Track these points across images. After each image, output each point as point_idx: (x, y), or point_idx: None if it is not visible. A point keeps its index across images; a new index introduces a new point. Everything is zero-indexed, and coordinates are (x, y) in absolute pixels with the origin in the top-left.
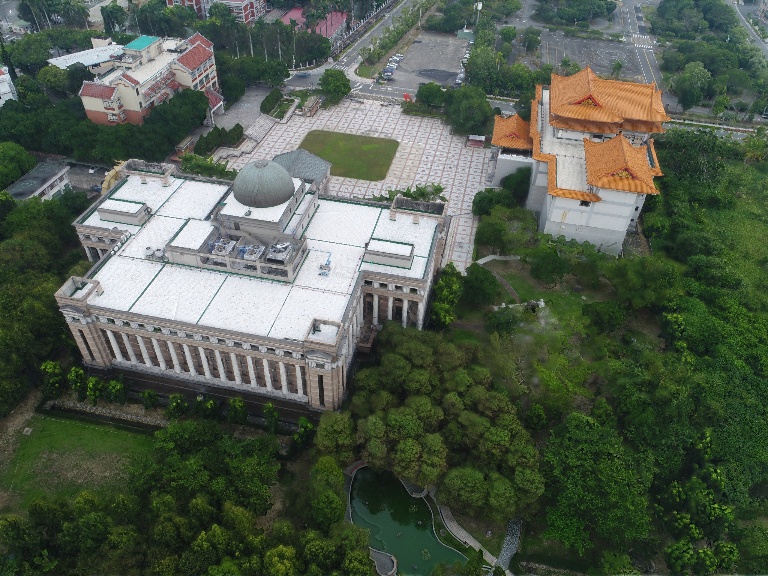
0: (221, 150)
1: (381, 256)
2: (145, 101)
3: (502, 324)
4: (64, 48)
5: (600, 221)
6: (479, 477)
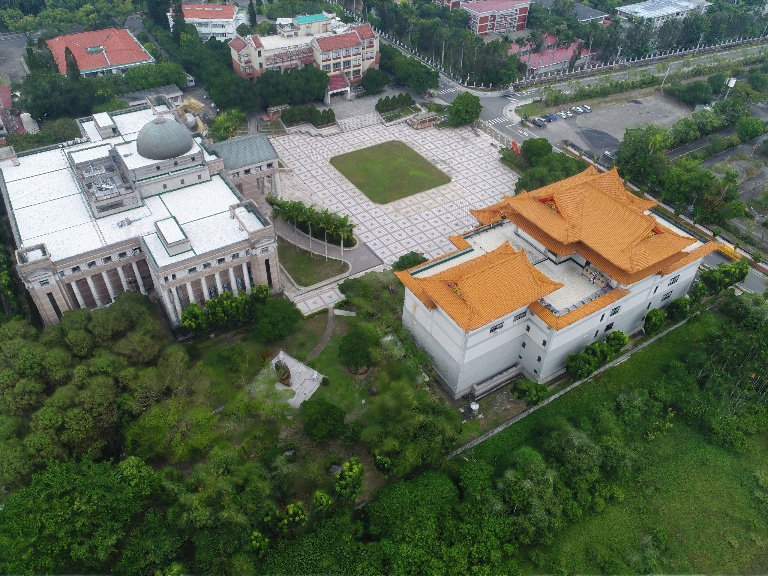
0: (308, 126)
1: (159, 233)
2: (267, 63)
3: (228, 359)
4: (310, 14)
5: (440, 336)
6: (1, 431)
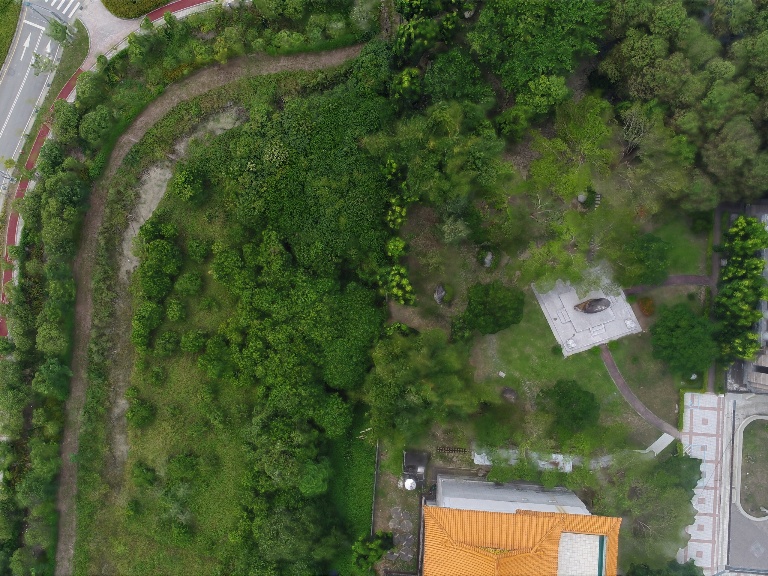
0: None
1: None
2: None
3: None
4: None
5: (496, 505)
6: None
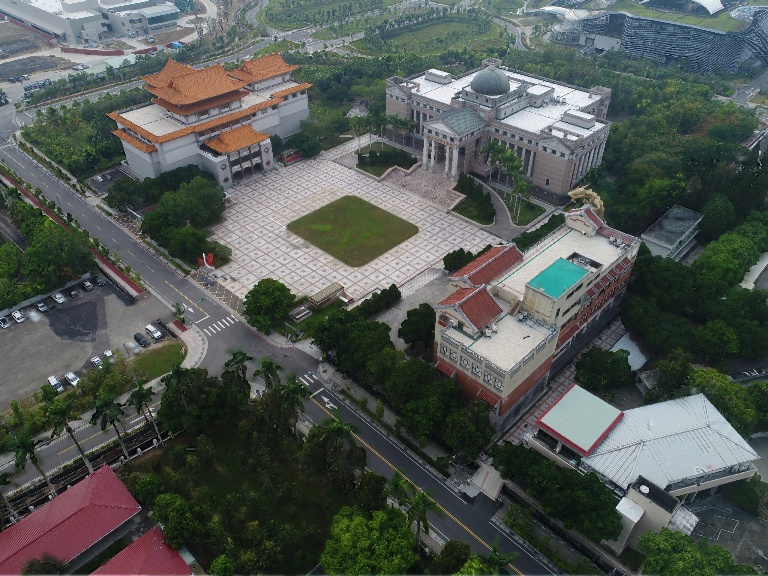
0: None
1: None
2: None
3: None
4: None
5: None
6: None
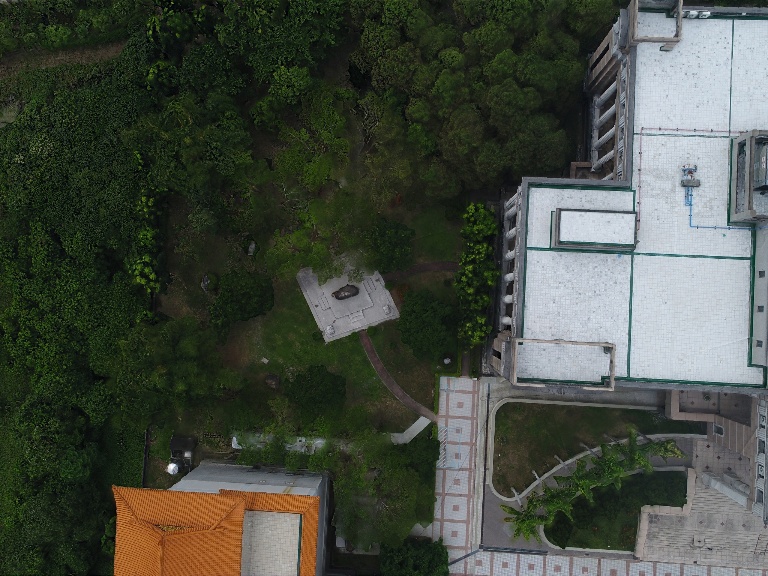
0: None
1: None
2: None
3: None
4: None
5: (225, 487)
6: None
